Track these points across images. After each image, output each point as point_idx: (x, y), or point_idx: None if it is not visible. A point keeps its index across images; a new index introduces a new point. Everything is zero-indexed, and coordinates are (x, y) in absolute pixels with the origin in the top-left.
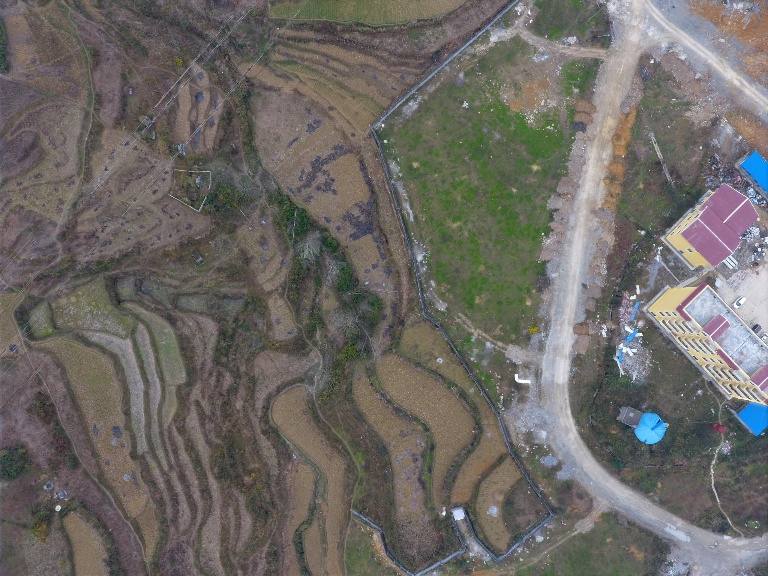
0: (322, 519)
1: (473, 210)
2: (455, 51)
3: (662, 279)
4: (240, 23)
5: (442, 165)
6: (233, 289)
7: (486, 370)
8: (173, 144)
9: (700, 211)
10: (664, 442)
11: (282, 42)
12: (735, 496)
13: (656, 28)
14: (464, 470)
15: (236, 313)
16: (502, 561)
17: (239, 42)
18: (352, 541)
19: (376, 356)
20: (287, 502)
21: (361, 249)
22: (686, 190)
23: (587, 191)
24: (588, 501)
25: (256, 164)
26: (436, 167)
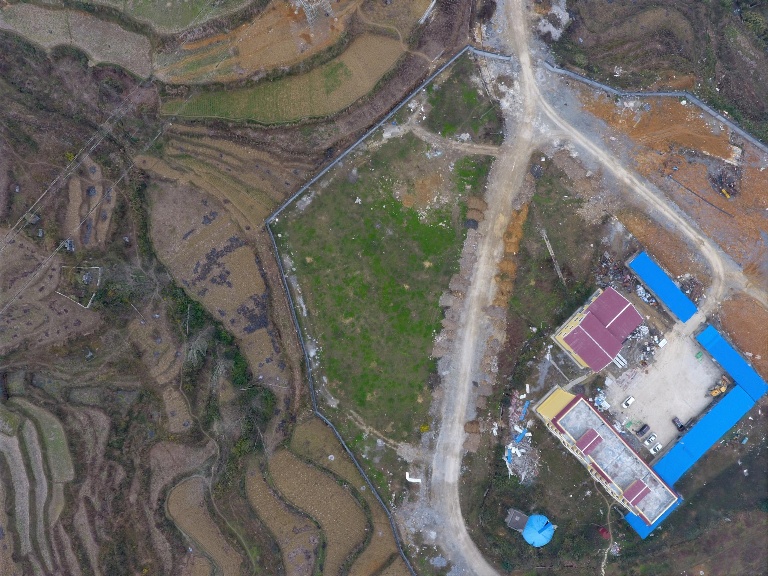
0: None
1: (365, 306)
2: (347, 148)
3: (552, 378)
4: (133, 118)
5: (335, 260)
6: (126, 382)
7: (378, 467)
8: (61, 241)
9: (584, 314)
10: (552, 544)
11: (175, 137)
12: None
13: (548, 125)
14: (354, 570)
15: (130, 405)
16: None
17: (132, 136)
18: None
19: (267, 453)
20: None
21: (255, 343)
22: (577, 287)
23: (478, 288)
24: None
25: (150, 257)
26: (329, 262)
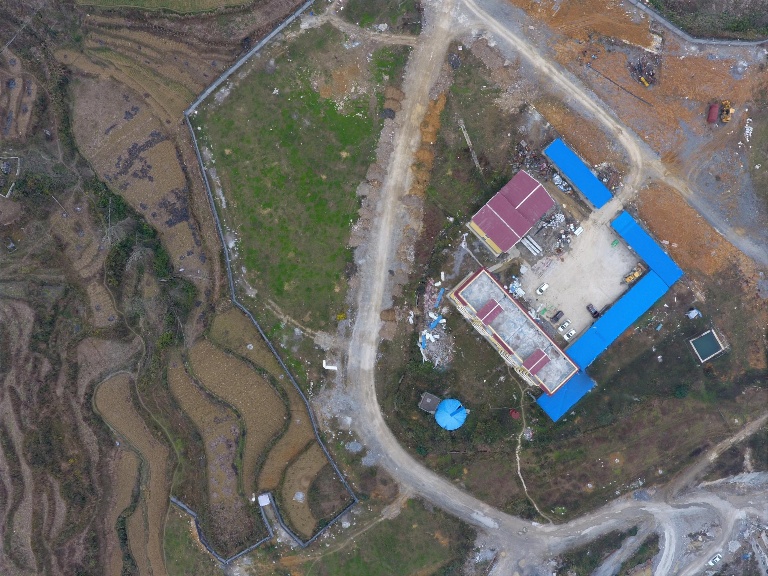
0: (145, 506)
1: (283, 197)
2: (263, 38)
3: (467, 266)
4: (51, 10)
5: (253, 152)
6: (50, 276)
7: (296, 356)
8: None
9: None
10: (465, 428)
11: (94, 29)
12: (539, 482)
13: (467, 15)
14: (272, 456)
15: (56, 300)
16: (309, 547)
17: (51, 29)
18: (171, 527)
19: (187, 342)
20: (110, 489)
21: (176, 236)
22: (494, 177)
23: (395, 178)
24: (393, 487)
25: (72, 151)
26: (247, 154)
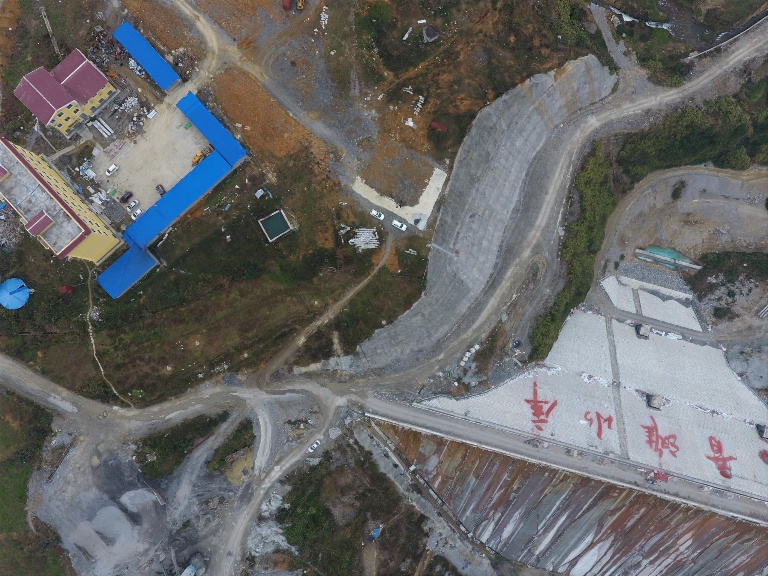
0: None
1: None
2: None
3: (39, 148)
4: None
5: None
6: None
7: None
8: None
9: None
10: (29, 308)
11: None
12: (112, 364)
13: None
14: None
15: None
16: None
17: None
18: None
19: None
20: None
21: None
22: None
23: None
24: None
25: None
26: None
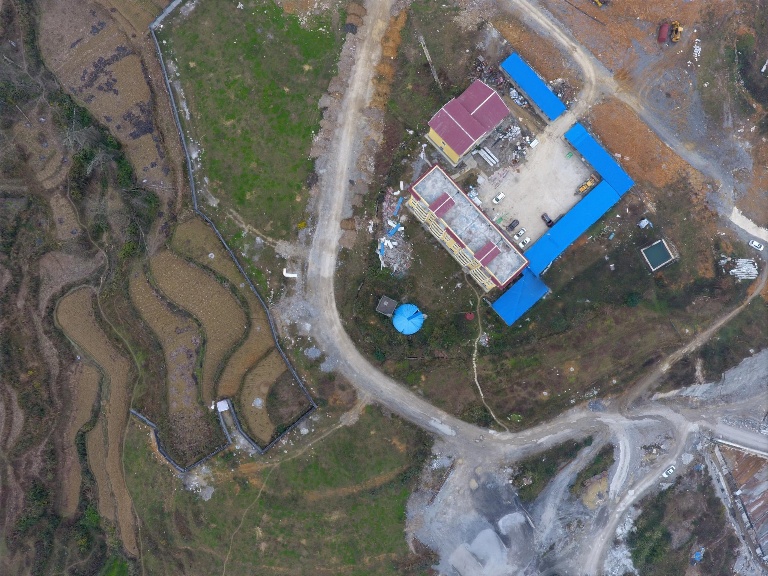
0: (105, 420)
1: (246, 108)
2: None
3: None
4: None
5: (217, 64)
6: (12, 186)
7: (257, 265)
8: None
9: None
10: (422, 333)
11: None
12: (495, 389)
13: None
14: (232, 363)
15: (18, 212)
16: (267, 453)
17: None
18: (130, 440)
19: (148, 251)
20: (70, 403)
21: (140, 148)
22: None
23: (356, 90)
24: (351, 393)
25: (37, 63)
26: (211, 66)
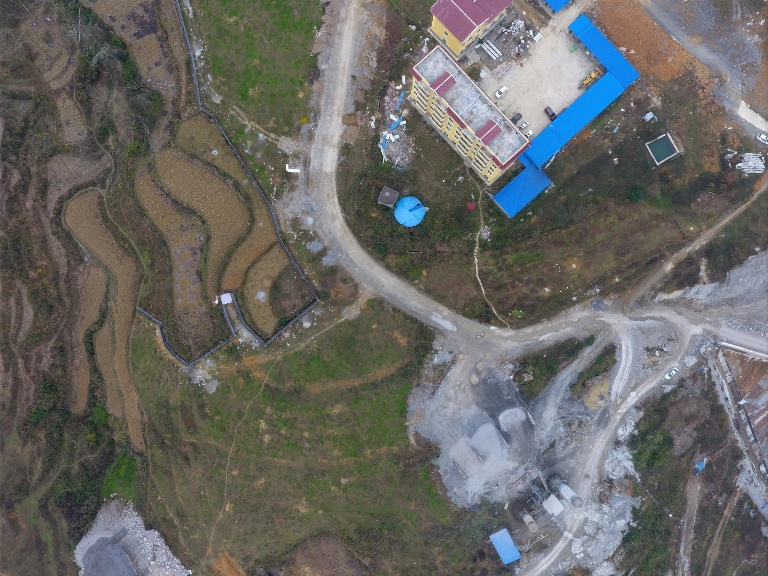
0: (112, 320)
1: (248, 5)
2: None
3: None
4: None
5: None
6: (20, 87)
7: (260, 162)
8: None
9: None
10: (424, 225)
11: None
12: (497, 283)
13: None
14: (235, 258)
15: (26, 113)
16: (270, 346)
17: None
18: (137, 338)
19: (153, 147)
20: (78, 303)
21: (145, 47)
22: None
23: None
24: (353, 286)
25: None
26: None
